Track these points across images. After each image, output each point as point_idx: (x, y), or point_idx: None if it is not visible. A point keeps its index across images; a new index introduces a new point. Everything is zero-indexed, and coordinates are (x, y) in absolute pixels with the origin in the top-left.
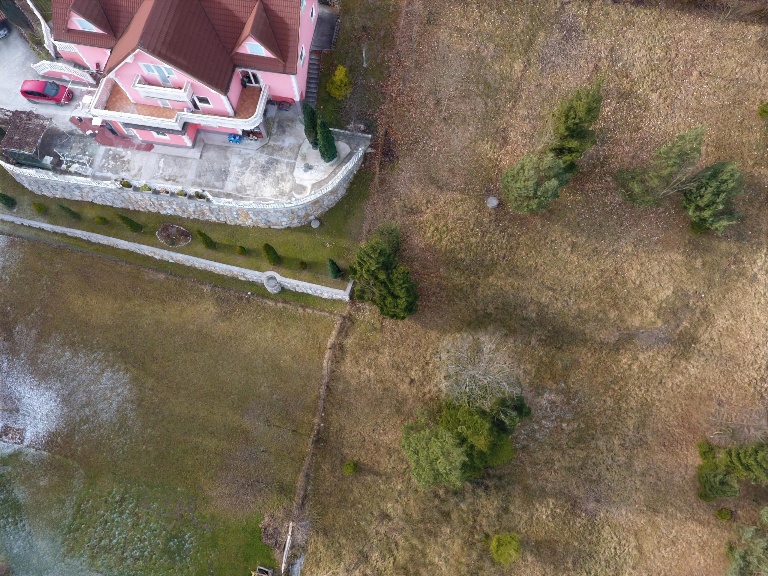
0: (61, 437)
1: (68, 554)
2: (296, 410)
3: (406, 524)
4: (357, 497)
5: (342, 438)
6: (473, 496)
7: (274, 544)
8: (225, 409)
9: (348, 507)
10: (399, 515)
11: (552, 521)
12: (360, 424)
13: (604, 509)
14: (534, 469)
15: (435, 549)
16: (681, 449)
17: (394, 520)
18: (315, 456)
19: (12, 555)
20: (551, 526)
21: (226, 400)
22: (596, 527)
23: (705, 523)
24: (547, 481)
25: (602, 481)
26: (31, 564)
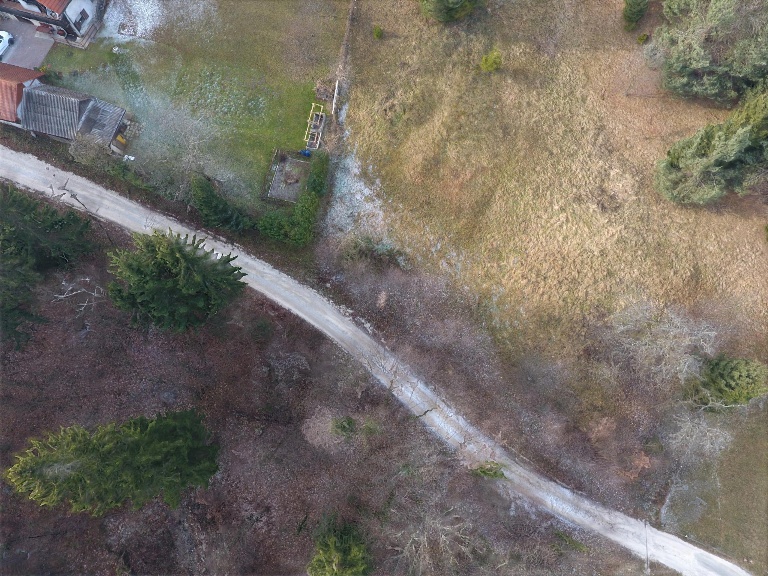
0: (164, 31)
1: (176, 108)
2: (335, 1)
3: (421, 64)
4: (384, 55)
5: (370, 14)
6: (467, 39)
7: (325, 97)
8: (283, 9)
9: (378, 63)
10: (415, 62)
11: (524, 57)
12: (383, 2)
13: (560, 51)
14: (509, 22)
15: (442, 80)
16: (611, 0)
17: (412, 66)
18: (351, 32)
19: (135, 108)
20: (523, 60)
21: (283, 2)
22: (555, 63)
23: (631, 50)
24: (519, 30)
25: (558, 31)
26: (149, 114)
